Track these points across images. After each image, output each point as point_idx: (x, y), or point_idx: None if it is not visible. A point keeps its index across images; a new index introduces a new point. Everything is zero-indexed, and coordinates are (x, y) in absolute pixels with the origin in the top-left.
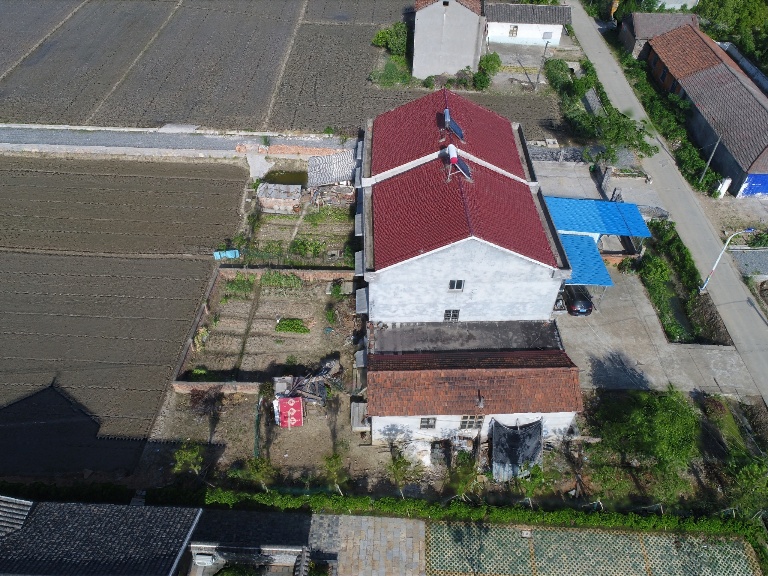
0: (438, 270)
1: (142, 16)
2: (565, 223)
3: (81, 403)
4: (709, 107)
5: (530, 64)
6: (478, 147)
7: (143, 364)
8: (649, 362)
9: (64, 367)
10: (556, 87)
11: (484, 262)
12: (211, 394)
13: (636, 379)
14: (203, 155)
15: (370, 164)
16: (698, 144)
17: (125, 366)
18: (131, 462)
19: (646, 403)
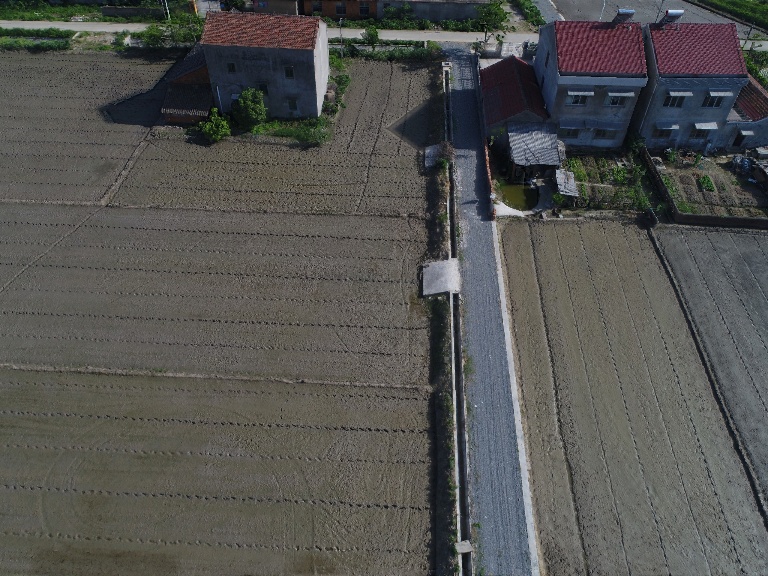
0: None
1: None
2: None
3: None
4: None
5: None
6: None
7: None
8: None
9: None
10: (345, 54)
11: None
12: None
13: None
14: None
15: None
16: None
17: None
18: None
19: None
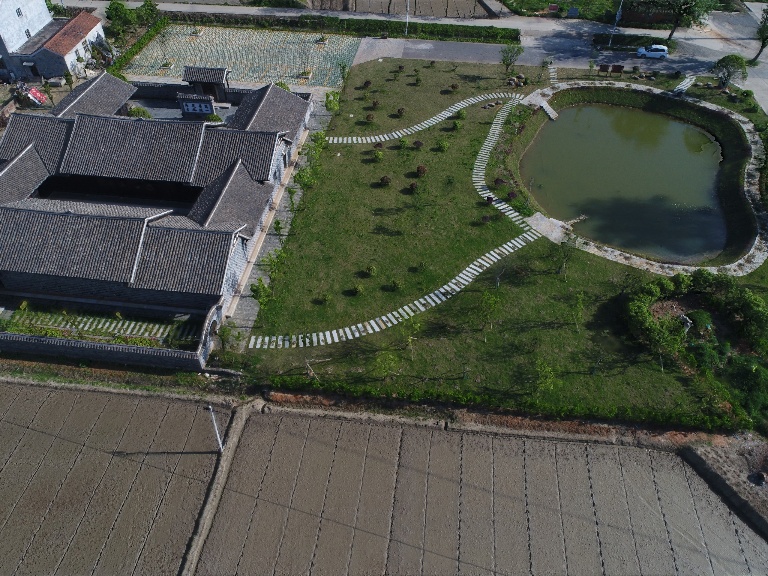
0: (10, 5)
1: None
2: None
3: None
4: None
5: None
6: None
7: None
8: None
9: None
10: None
11: None
12: (5, 117)
13: None
14: None
15: None
16: None
17: None
18: None
19: (109, 10)
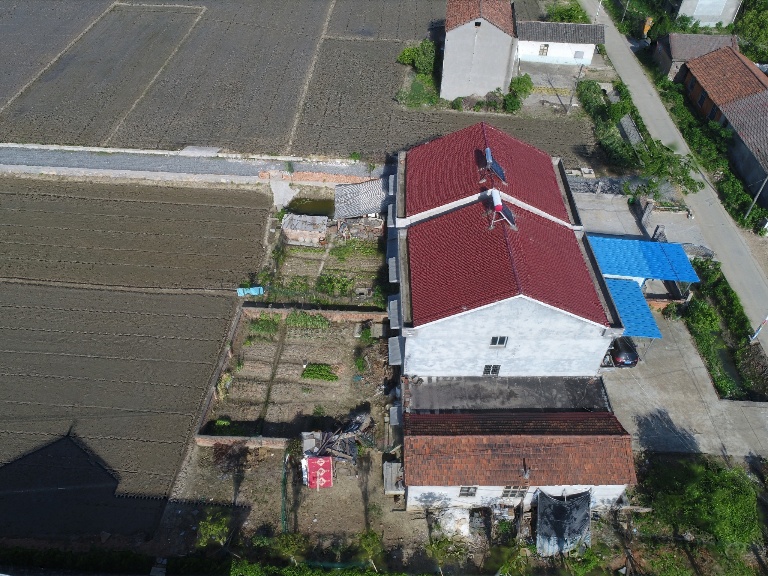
0: (481, 326)
1: (162, 29)
2: (608, 266)
3: (98, 456)
4: (754, 137)
5: (561, 85)
6: (520, 188)
7: (163, 412)
8: (700, 421)
9: (81, 414)
10: (589, 111)
11: (531, 319)
12: (235, 449)
13: (687, 440)
14: (225, 181)
15: (404, 202)
16: (740, 175)
17: (145, 414)
18: (151, 524)
19: (704, 476)
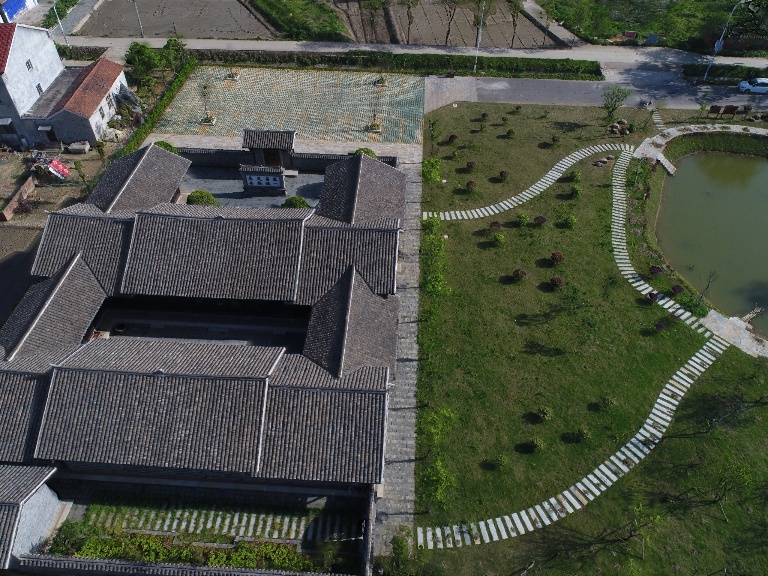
0: (19, 58)
1: None
2: None
3: None
4: None
5: None
6: None
7: None
8: None
9: None
10: None
11: (27, 41)
12: (23, 200)
13: None
14: None
15: None
16: None
17: None
18: None
19: (130, 53)
